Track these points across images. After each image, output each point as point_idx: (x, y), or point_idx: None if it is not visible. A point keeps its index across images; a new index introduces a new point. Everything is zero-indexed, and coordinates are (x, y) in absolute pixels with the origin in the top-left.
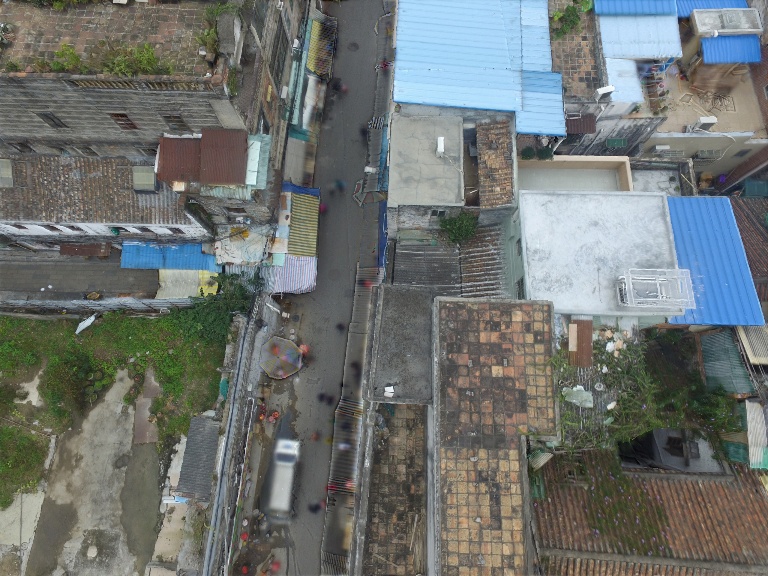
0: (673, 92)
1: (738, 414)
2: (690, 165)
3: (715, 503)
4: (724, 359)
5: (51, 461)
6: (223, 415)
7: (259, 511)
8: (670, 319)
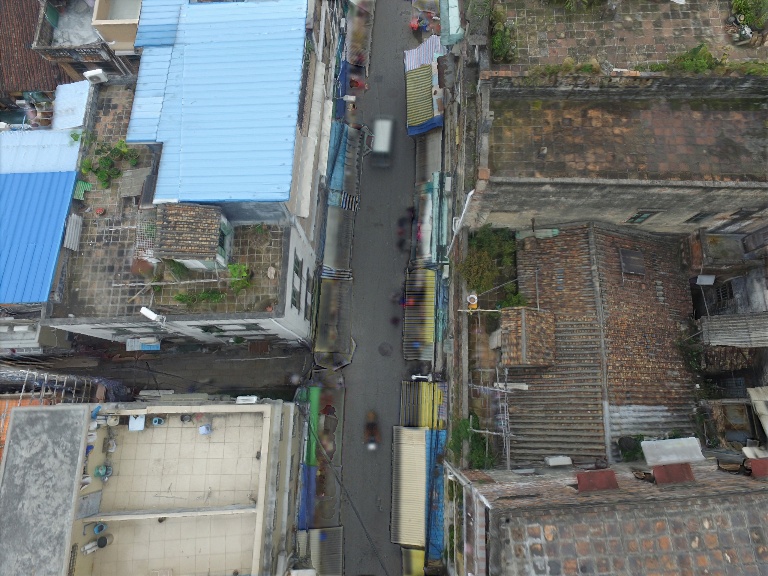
0: None
1: None
2: (36, 43)
3: None
4: None
5: None
6: None
7: None
8: None
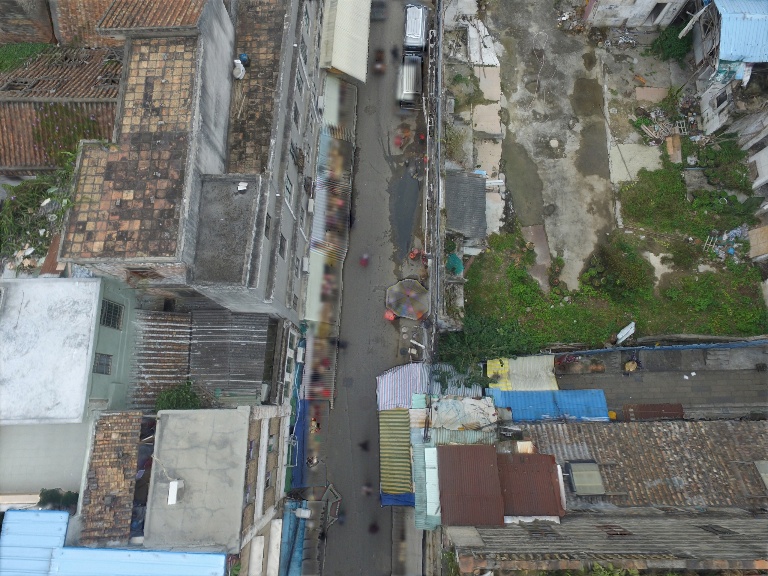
0: None
1: None
2: None
3: None
4: None
5: (616, 207)
6: None
7: (418, 179)
8: None
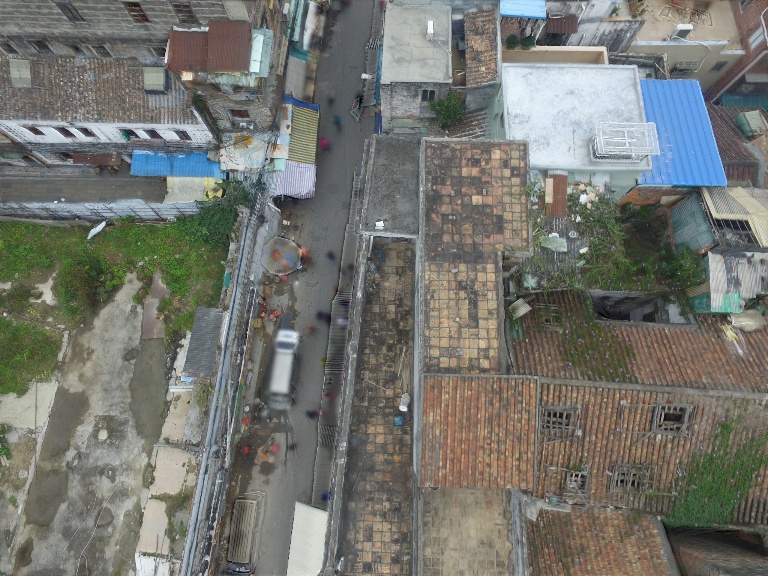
0: (654, 9)
1: (702, 268)
2: (665, 59)
3: (679, 345)
4: (691, 222)
5: (64, 354)
6: (227, 294)
7: (260, 400)
8: (640, 180)
